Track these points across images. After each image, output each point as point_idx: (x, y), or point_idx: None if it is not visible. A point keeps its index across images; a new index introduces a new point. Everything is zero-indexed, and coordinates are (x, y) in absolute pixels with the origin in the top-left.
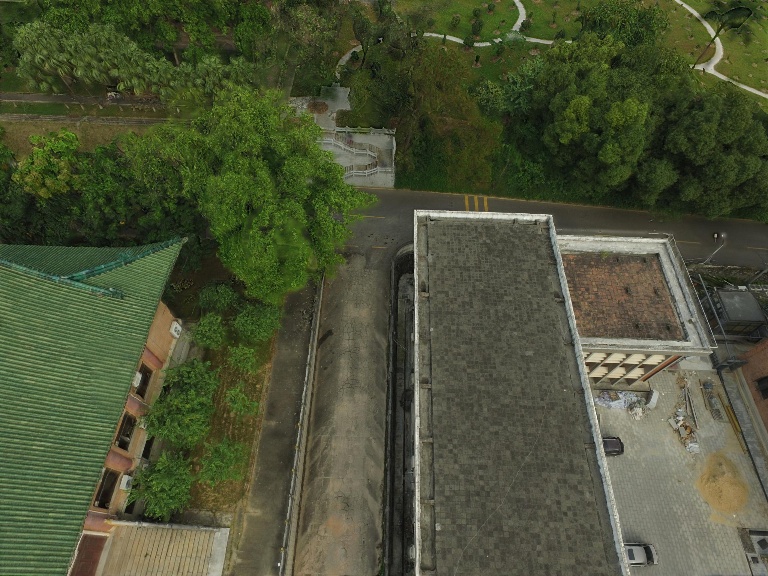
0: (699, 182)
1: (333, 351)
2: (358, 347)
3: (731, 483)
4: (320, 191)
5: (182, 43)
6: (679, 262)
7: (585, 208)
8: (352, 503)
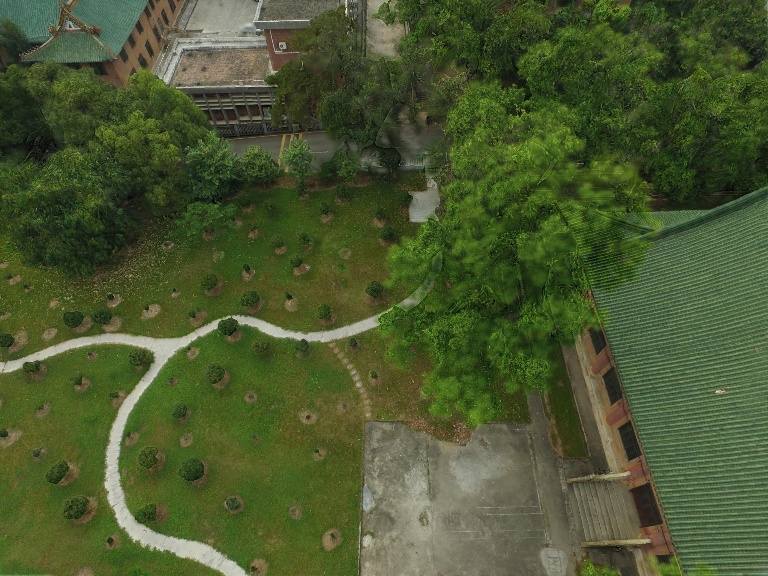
0: None
1: None
2: None
3: None
4: None
5: None
6: None
7: None
8: (381, 42)
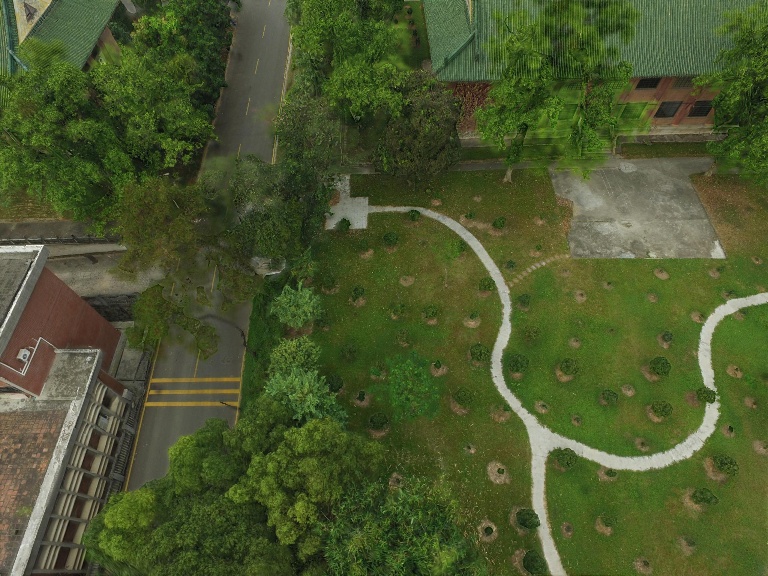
0: None
1: (78, 266)
2: (75, 284)
3: None
4: (53, 160)
5: None
6: None
7: None
8: None
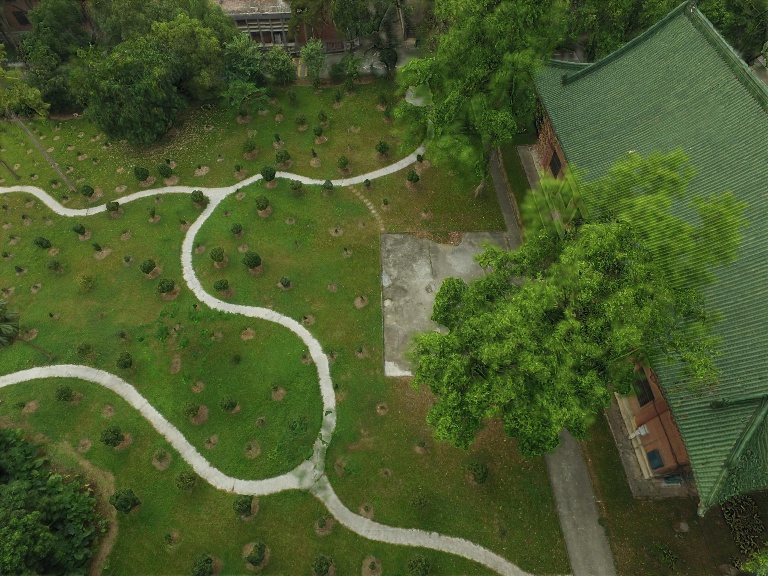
0: None
1: (391, 17)
2: None
3: None
4: None
5: (572, 42)
6: None
7: None
8: None
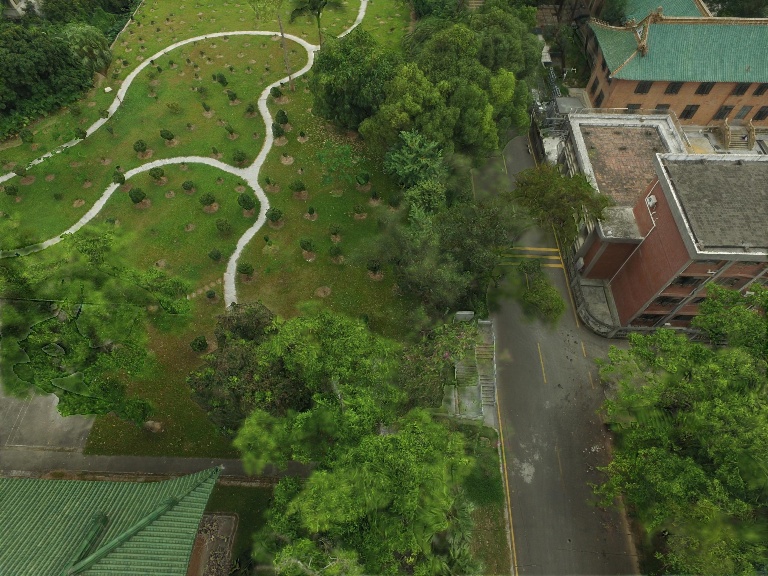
0: (528, 77)
1: None
2: None
3: (694, 149)
4: None
5: None
6: (596, 112)
7: (474, 175)
8: None
